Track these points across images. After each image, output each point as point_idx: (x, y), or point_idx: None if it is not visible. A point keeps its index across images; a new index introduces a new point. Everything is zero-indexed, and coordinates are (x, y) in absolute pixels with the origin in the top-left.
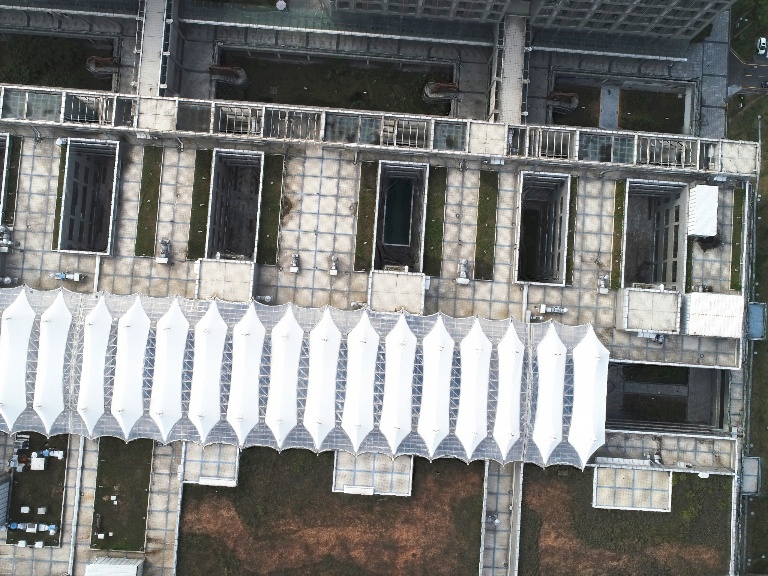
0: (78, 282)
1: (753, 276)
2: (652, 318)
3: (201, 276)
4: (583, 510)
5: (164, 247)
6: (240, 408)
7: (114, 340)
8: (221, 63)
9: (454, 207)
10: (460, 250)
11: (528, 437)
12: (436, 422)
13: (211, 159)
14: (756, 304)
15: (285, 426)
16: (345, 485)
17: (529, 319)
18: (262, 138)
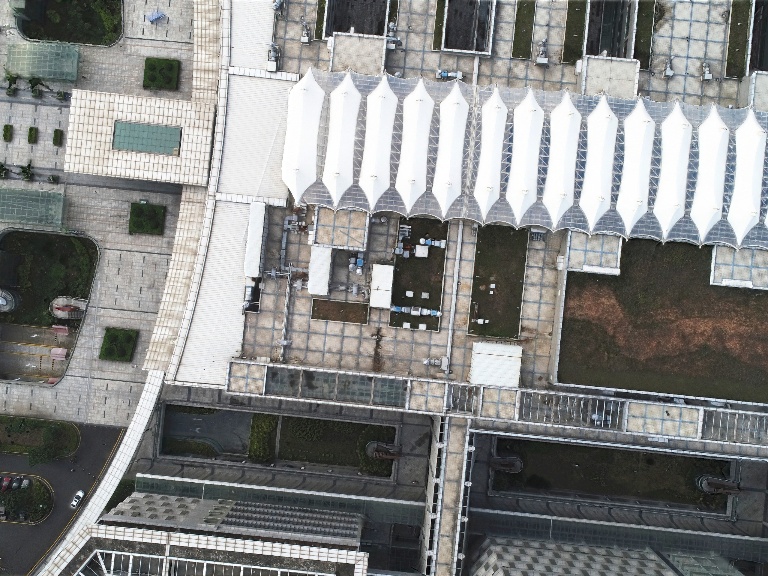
0: None
1: None
2: None
3: (587, 73)
4: None
5: (543, 48)
6: (639, 193)
7: (510, 129)
8: None
9: None
10: None
11: None
12: None
13: None
14: None
15: (676, 215)
16: (724, 278)
17: None
18: None
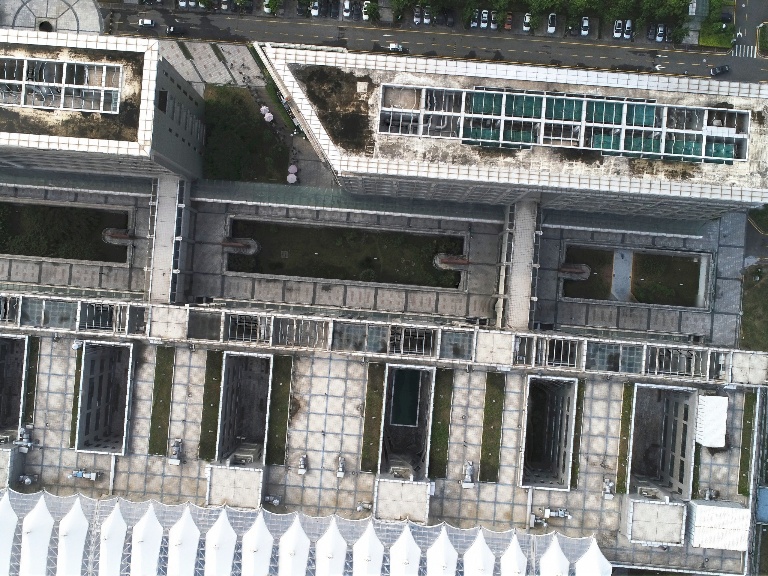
0: (94, 481)
1: (764, 452)
2: (656, 529)
3: (212, 482)
4: None
5: (176, 448)
6: None
7: (129, 548)
8: (233, 234)
9: (460, 408)
10: (466, 452)
11: None
12: None
13: (221, 361)
14: (766, 488)
15: None
16: None
17: (533, 523)
18: (271, 347)
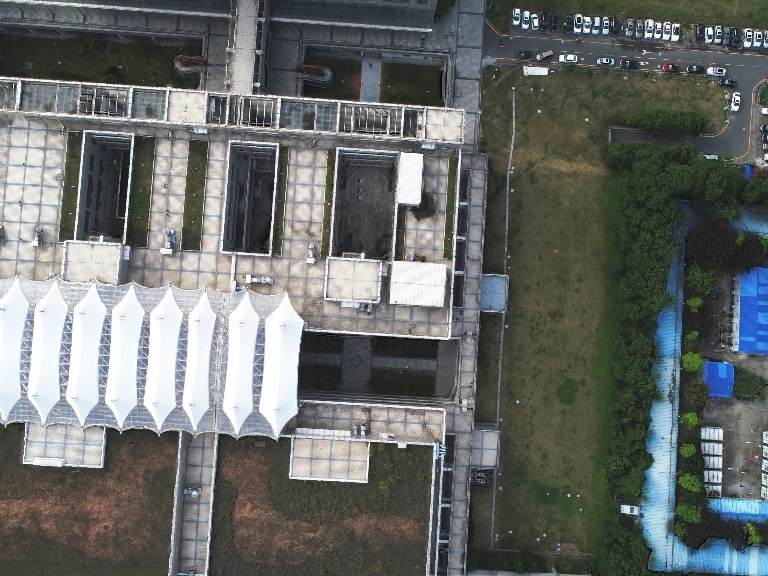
0: None
1: (505, 249)
2: (353, 287)
3: None
4: (280, 481)
5: None
6: None
7: None
8: None
9: (163, 177)
10: (168, 220)
11: (218, 407)
12: (115, 392)
13: None
14: (498, 276)
15: None
16: (35, 457)
17: (234, 289)
18: None
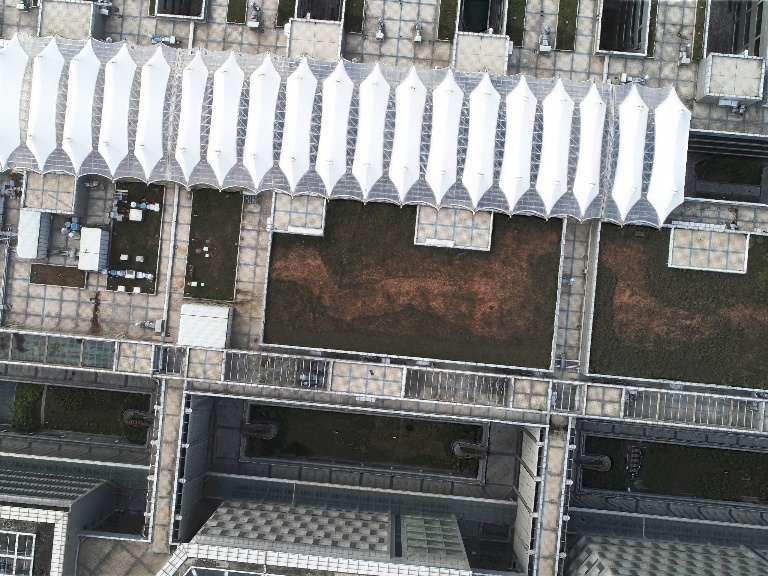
0: (174, 45)
1: None
2: (735, 84)
3: (292, 36)
4: (658, 270)
5: (255, 12)
6: (330, 153)
7: (210, 91)
8: None
9: None
10: (542, 21)
11: (607, 193)
12: (519, 170)
13: None
14: None
15: (372, 174)
16: (427, 238)
17: None
18: None
